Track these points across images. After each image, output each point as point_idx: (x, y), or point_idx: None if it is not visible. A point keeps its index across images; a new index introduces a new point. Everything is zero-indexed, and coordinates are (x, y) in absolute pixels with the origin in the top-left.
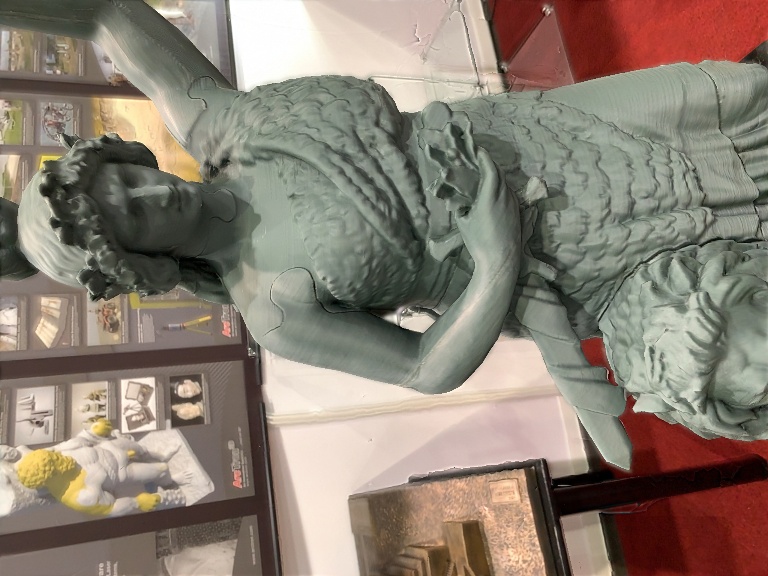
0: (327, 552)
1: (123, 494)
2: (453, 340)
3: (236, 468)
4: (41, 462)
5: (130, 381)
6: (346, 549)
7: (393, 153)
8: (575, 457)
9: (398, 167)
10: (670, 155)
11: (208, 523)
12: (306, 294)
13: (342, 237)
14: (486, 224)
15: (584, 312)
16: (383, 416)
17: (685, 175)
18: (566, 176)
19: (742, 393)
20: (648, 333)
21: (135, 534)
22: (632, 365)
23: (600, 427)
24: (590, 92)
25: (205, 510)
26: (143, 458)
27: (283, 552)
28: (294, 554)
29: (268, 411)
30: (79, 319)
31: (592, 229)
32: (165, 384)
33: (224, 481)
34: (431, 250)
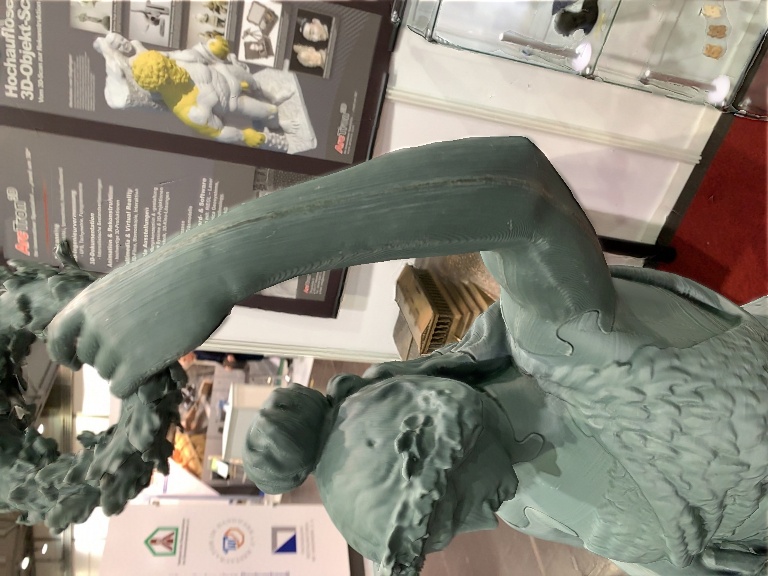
0: None
1: (231, 123)
2: None
3: (342, 133)
4: (155, 65)
5: None
6: None
7: (749, 507)
8: (654, 222)
9: (742, 515)
10: None
11: (303, 174)
12: None
13: (634, 558)
14: None
15: None
16: (500, 125)
17: None
18: None
19: None
20: None
21: (237, 163)
22: None
23: None
24: None
25: (303, 162)
26: (255, 94)
27: None
28: None
29: (390, 83)
30: None
31: None
32: (292, 16)
33: (327, 142)
34: (706, 560)
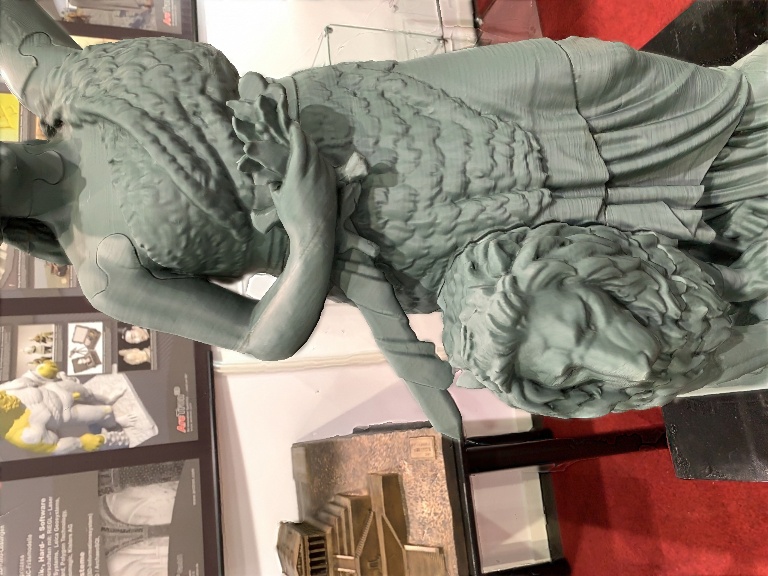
0: (269, 496)
1: (67, 434)
2: (275, 311)
3: (181, 413)
4: None
5: (77, 325)
6: (287, 494)
7: (217, 122)
8: (520, 416)
9: (222, 137)
10: (514, 134)
11: (150, 464)
12: (129, 260)
13: (155, 206)
14: (293, 200)
15: (422, 287)
16: (331, 369)
17: (527, 155)
18: (399, 152)
19: (544, 374)
20: (463, 312)
21: (78, 472)
22: (454, 342)
23: (427, 399)
24: (442, 65)
25: (148, 452)
26: (88, 400)
27: (225, 494)
28: (236, 497)
29: (216, 359)
30: (26, 261)
31: (421, 207)
32: (113, 329)
33: (168, 425)
34: (253, 222)
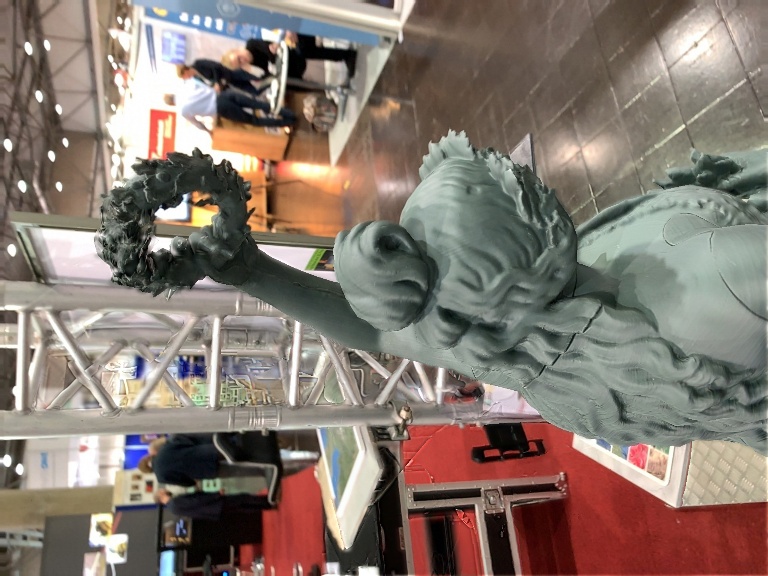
0: None
1: None
2: None
3: None
4: None
5: None
6: None
7: None
8: None
9: None
10: None
11: None
12: (703, 224)
13: None
14: (759, 152)
15: None
16: None
17: None
18: None
19: None
20: None
21: None
22: None
23: None
24: None
25: None
26: None
27: None
28: None
29: None
30: None
31: None
32: None
33: None
34: (757, 199)
